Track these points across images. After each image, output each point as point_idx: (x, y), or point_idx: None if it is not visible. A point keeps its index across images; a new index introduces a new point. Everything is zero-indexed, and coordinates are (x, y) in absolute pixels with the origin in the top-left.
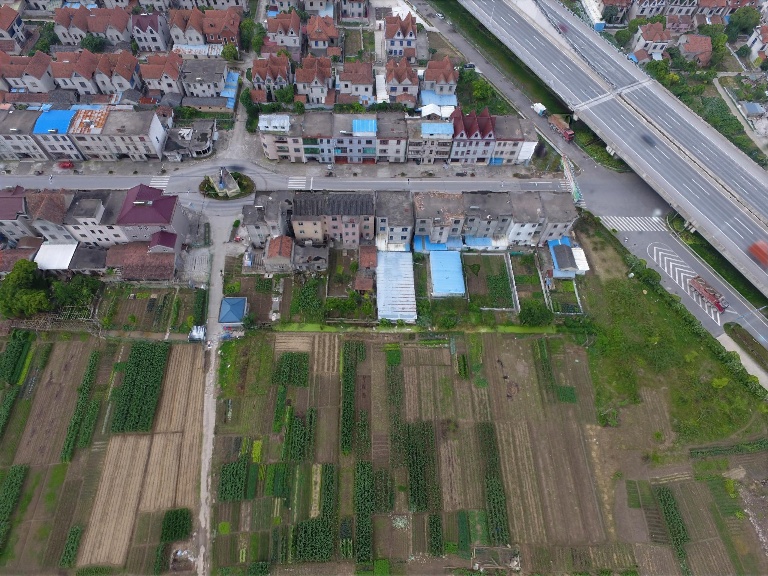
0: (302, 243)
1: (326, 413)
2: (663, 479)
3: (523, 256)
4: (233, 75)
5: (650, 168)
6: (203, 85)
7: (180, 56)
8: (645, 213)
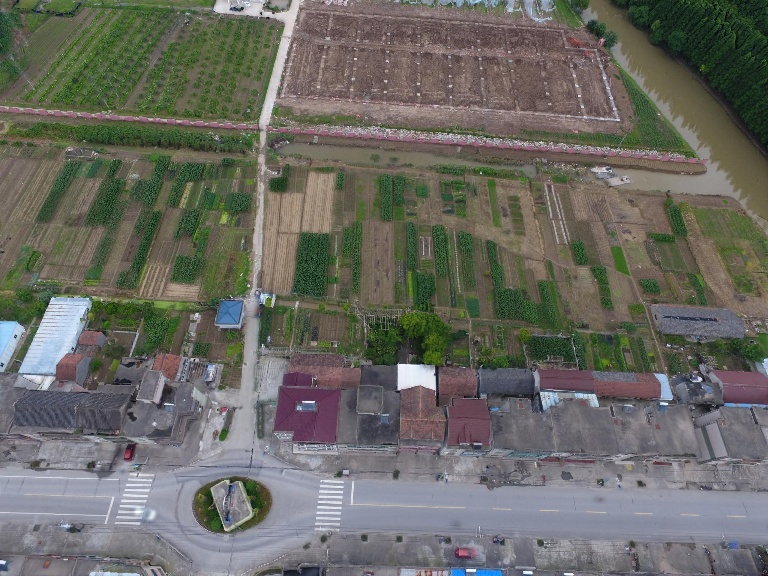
0: None
1: (167, 237)
2: None
3: None
4: None
5: None
6: None
7: None
8: None
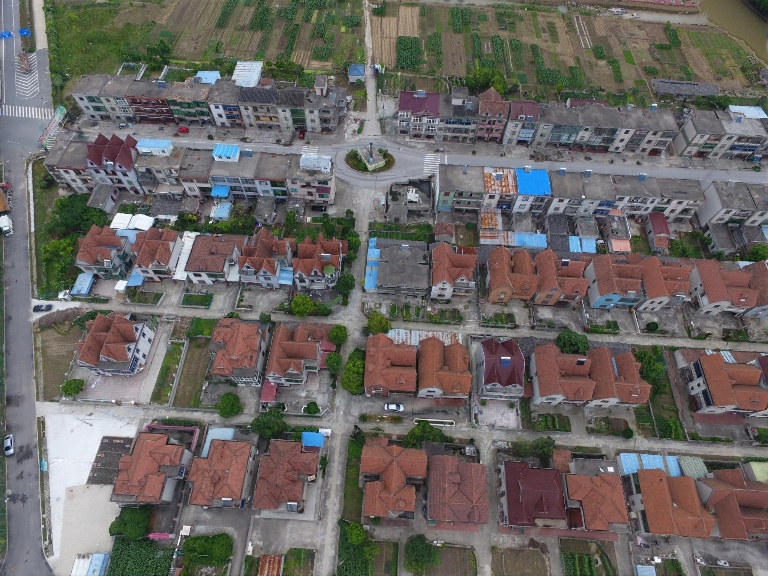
0: None
1: (305, 38)
2: (141, 2)
3: None
4: None
5: None
6: None
7: None
8: (7, 119)
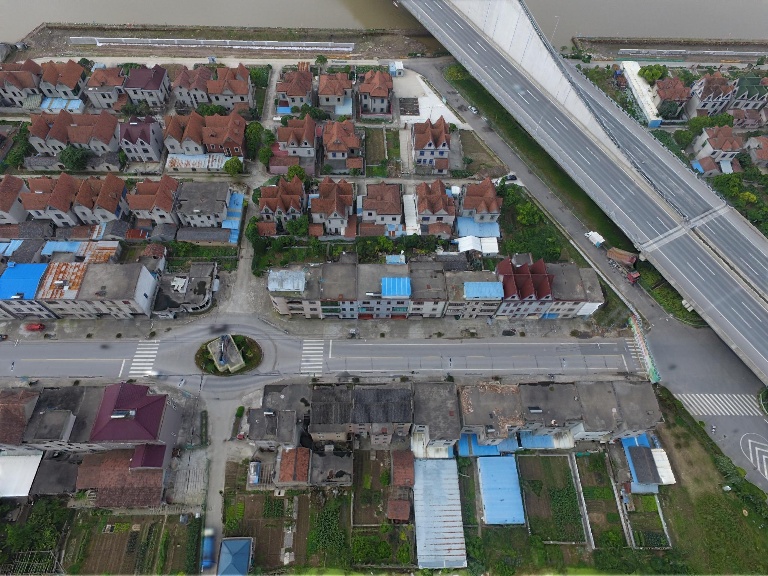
0: (320, 443)
1: None
2: None
3: (591, 458)
4: (237, 198)
5: (739, 335)
6: (202, 216)
7: (176, 169)
8: (732, 388)
